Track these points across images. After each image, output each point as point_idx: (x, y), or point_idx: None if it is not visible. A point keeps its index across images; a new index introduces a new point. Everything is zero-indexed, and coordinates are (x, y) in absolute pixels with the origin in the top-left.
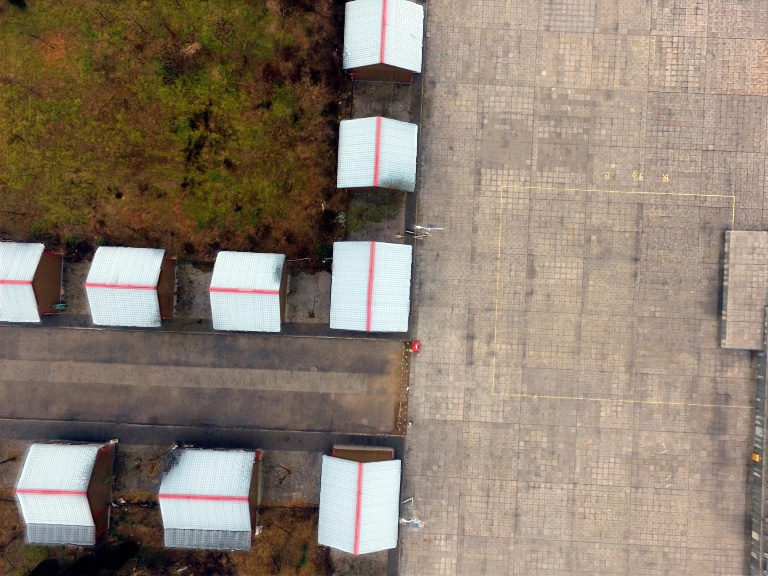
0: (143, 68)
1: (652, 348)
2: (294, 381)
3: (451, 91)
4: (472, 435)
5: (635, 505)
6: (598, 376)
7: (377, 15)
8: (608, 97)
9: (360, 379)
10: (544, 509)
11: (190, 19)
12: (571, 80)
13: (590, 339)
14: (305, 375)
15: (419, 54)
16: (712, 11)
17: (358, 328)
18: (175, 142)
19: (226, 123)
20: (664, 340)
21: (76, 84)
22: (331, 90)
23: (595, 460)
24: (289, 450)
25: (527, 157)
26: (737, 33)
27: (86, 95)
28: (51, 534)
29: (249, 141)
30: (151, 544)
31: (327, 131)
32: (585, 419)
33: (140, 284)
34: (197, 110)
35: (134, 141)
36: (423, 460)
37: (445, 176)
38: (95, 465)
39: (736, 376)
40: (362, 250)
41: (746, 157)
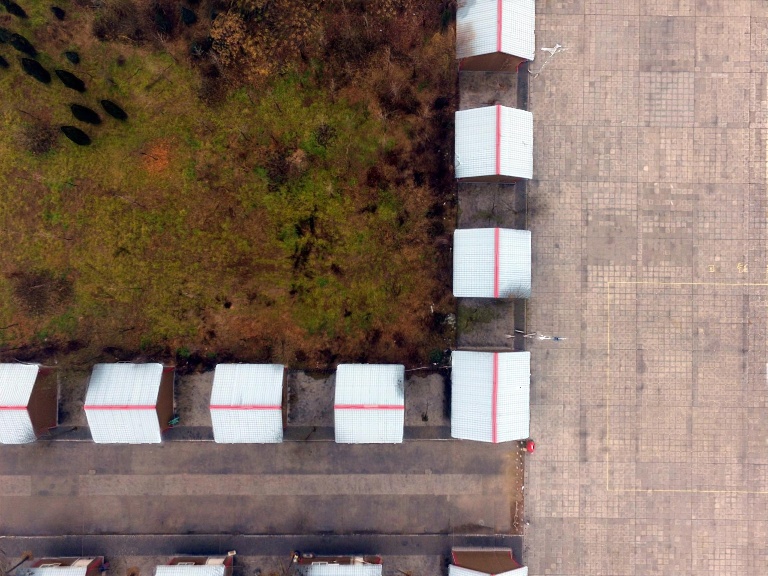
0: (247, 176)
1: (763, 438)
2: (409, 484)
3: (555, 189)
4: (589, 532)
5: None
6: (711, 468)
7: (491, 126)
8: (710, 190)
9: (475, 480)
10: None
11: (292, 125)
12: (673, 175)
13: (702, 431)
14: (420, 478)
15: (530, 161)
16: None
17: (483, 439)
18: (282, 249)
19: (332, 228)
20: None
21: (180, 194)
22: (435, 192)
23: (711, 552)
24: (407, 554)
25: (632, 252)
26: None
27: (191, 205)
28: None
29: (356, 246)
30: None
31: (441, 240)
32: (700, 511)
33: (264, 404)
34: (303, 216)
35: (241, 250)
36: (541, 559)
37: (552, 274)
38: None
39: None
40: (484, 361)
41: None
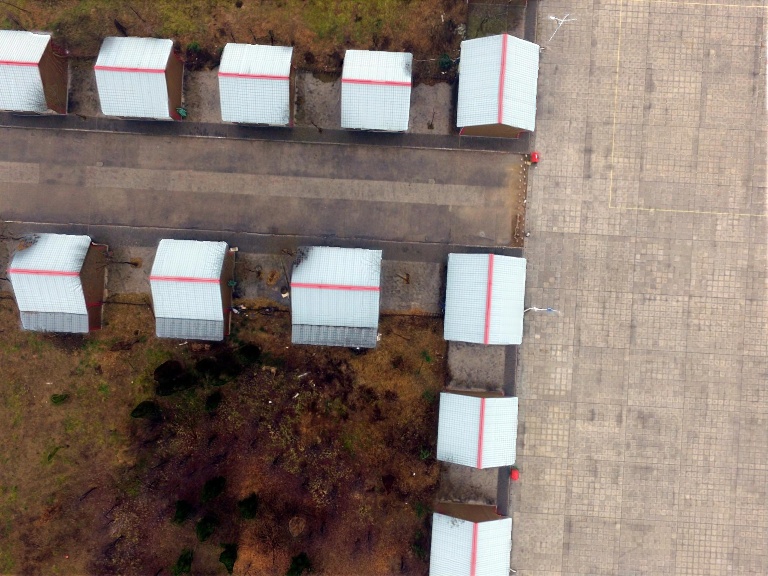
0: None
1: None
2: (412, 193)
3: None
4: (589, 248)
5: (750, 317)
6: (715, 190)
7: None
8: None
9: (478, 192)
10: (659, 321)
11: None
12: None
13: (707, 153)
14: (423, 187)
15: None
16: None
17: (489, 122)
18: None
19: None
20: None
21: None
22: None
23: (710, 273)
24: (407, 260)
25: None
26: None
27: None
28: (179, 329)
29: None
30: (271, 350)
31: None
32: (701, 232)
33: (272, 74)
34: None
35: None
36: (540, 272)
37: None
38: (225, 258)
39: None
40: (493, 44)
41: None
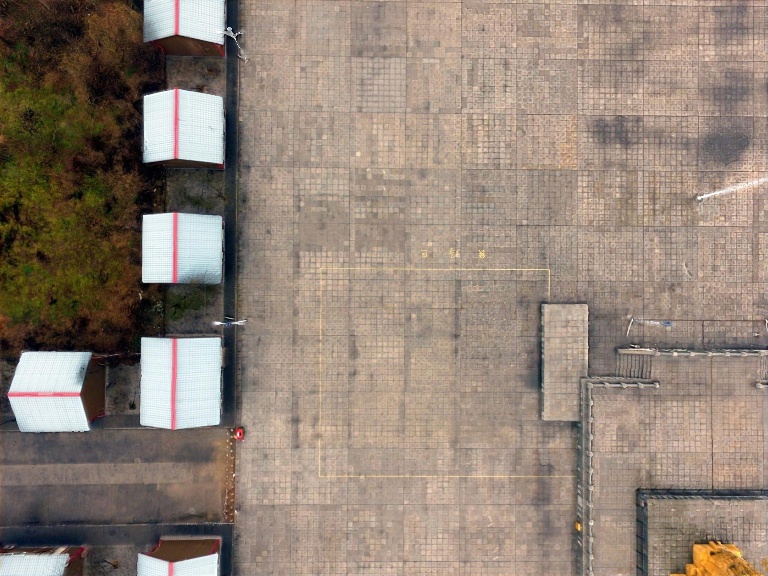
0: None
1: (475, 423)
2: (118, 474)
3: (266, 175)
4: (300, 518)
5: None
6: (423, 453)
7: (171, 110)
8: (422, 176)
9: (185, 468)
10: None
11: None
12: (385, 160)
13: (414, 417)
14: (129, 467)
15: (220, 145)
16: (520, 88)
17: (164, 426)
18: None
19: (37, 215)
20: (486, 414)
21: None
22: (145, 178)
23: (423, 537)
24: (114, 544)
25: (345, 238)
26: (545, 109)
27: None
28: None
29: (62, 233)
30: None
31: (131, 225)
32: (412, 496)
33: None
34: (6, 203)
35: None
36: (252, 546)
37: (263, 260)
38: None
39: (558, 446)
40: (165, 347)
41: (559, 230)
